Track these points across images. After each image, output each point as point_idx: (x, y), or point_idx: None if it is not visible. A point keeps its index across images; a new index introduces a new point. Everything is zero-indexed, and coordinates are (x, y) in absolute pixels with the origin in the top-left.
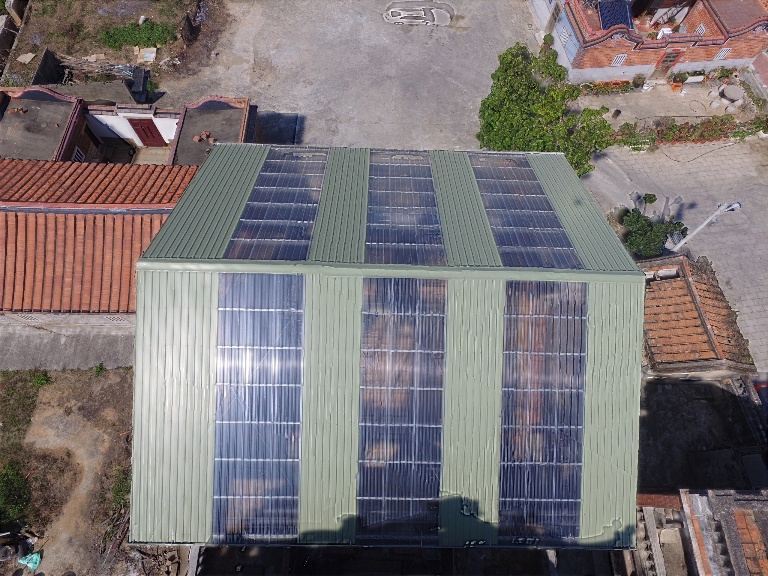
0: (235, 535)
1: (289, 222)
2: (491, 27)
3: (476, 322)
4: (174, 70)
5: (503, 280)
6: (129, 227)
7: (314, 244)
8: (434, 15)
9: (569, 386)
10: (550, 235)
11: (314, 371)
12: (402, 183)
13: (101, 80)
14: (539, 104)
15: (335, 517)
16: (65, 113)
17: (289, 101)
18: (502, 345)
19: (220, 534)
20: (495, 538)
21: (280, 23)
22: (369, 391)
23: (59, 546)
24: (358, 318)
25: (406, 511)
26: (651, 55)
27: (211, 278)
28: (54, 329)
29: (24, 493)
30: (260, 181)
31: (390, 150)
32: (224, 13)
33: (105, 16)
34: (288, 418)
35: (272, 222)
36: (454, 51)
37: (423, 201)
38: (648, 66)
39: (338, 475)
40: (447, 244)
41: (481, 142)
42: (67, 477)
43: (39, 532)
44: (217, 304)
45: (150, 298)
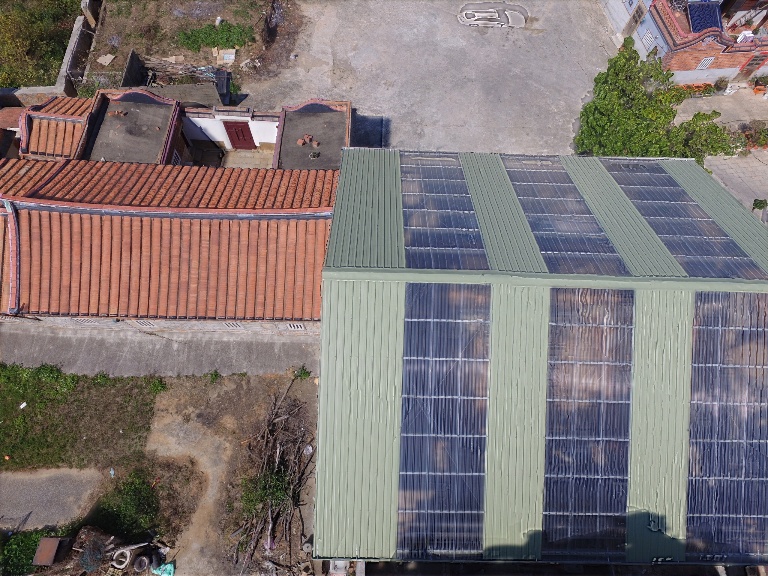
0: (420, 550)
1: (454, 230)
2: (566, 29)
3: (664, 334)
4: (255, 72)
5: (692, 291)
6: (255, 232)
7: (490, 253)
8: (508, 17)
9: (758, 399)
10: (721, 244)
11: (501, 383)
12: (547, 189)
13: (187, 82)
14: (650, 108)
15: (521, 532)
16: (165, 116)
17: (372, 104)
18: (691, 357)
19: (405, 549)
20: (683, 555)
21: (355, 25)
22: (556, 404)
23: (191, 556)
24: (545, 329)
25: (593, 527)
26: (738, 58)
27: (397, 288)
28: (165, 335)
29: (152, 502)
30: (406, 187)
31: (519, 155)
32: (299, 14)
33: (180, 17)
34: (474, 431)
35: (437, 230)
36: (532, 53)
37: (577, 208)
38: (733, 69)
39: (524, 490)
40: (622, 253)
41: (579, 146)
42: (193, 486)
43: (170, 542)
44: (404, 314)
45: (336, 308)
